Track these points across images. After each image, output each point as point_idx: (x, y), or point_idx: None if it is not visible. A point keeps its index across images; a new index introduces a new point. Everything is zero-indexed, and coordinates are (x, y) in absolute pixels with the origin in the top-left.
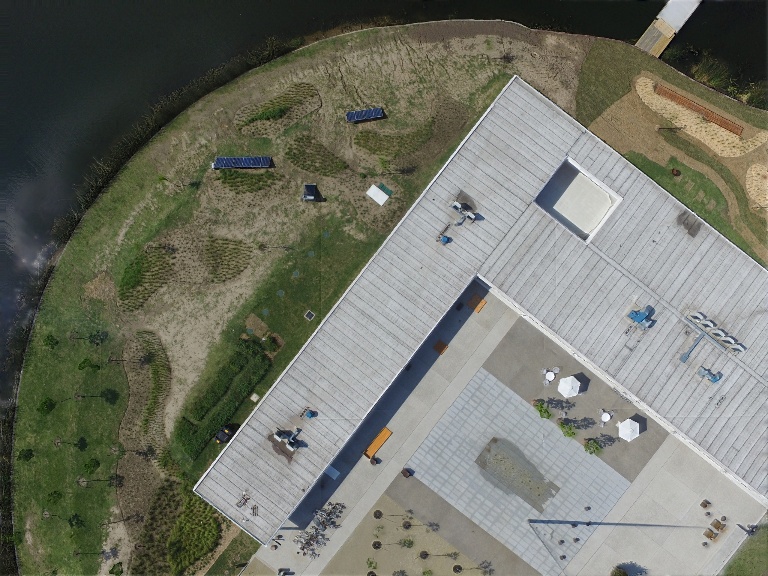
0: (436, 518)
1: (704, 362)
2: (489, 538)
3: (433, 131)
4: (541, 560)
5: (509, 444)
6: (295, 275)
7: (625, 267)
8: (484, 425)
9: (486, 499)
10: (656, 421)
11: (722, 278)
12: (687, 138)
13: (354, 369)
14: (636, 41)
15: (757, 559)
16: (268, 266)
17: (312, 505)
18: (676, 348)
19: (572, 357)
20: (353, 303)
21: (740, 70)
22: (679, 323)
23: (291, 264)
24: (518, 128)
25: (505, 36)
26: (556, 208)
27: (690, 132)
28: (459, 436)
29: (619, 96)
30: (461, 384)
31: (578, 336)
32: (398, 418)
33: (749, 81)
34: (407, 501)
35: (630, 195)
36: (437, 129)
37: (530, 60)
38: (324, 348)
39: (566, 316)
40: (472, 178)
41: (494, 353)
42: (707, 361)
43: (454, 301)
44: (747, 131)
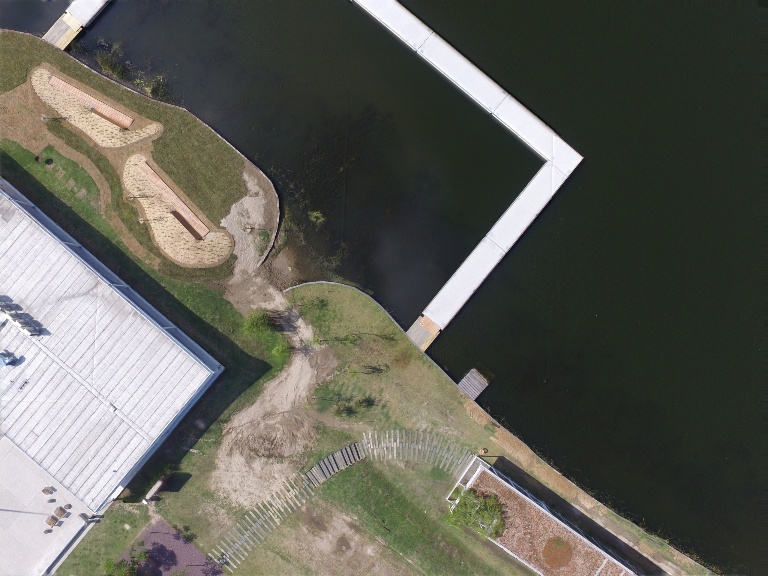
0: None
1: (9, 346)
2: None
3: None
4: None
5: None
6: None
7: None
8: None
9: None
10: None
11: (31, 263)
12: (70, 128)
13: None
14: None
15: (104, 550)
16: None
17: None
18: None
19: None
20: None
21: (149, 63)
22: None
23: None
24: None
25: None
26: None
27: (74, 122)
28: None
29: (12, 86)
30: None
31: None
32: None
33: (156, 74)
34: None
35: None
36: None
37: None
38: None
39: None
40: None
41: None
42: (12, 345)
43: None
44: (138, 123)
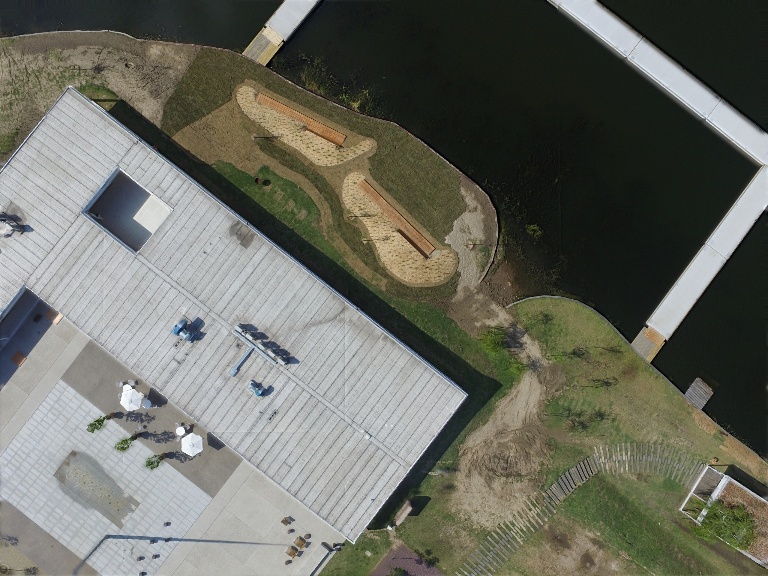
0: (15, 532)
1: (255, 376)
2: (68, 553)
3: (15, 142)
4: None
5: (88, 458)
6: None
7: (174, 279)
8: (63, 438)
9: (65, 513)
10: None
11: (274, 290)
12: (283, 147)
13: None
14: (244, 50)
15: None
16: None
17: None
18: (227, 361)
19: None
20: None
21: (353, 77)
22: (230, 336)
23: None
24: (69, 139)
25: (108, 47)
26: (136, 219)
27: (286, 141)
28: (38, 449)
29: (218, 105)
30: (40, 396)
31: (125, 349)
32: None
33: (362, 88)
34: None
35: (181, 206)
36: (19, 140)
37: (121, 70)
38: None
39: (114, 328)
40: (22, 189)
41: (73, 365)
42: (259, 375)
43: None
44: (351, 139)
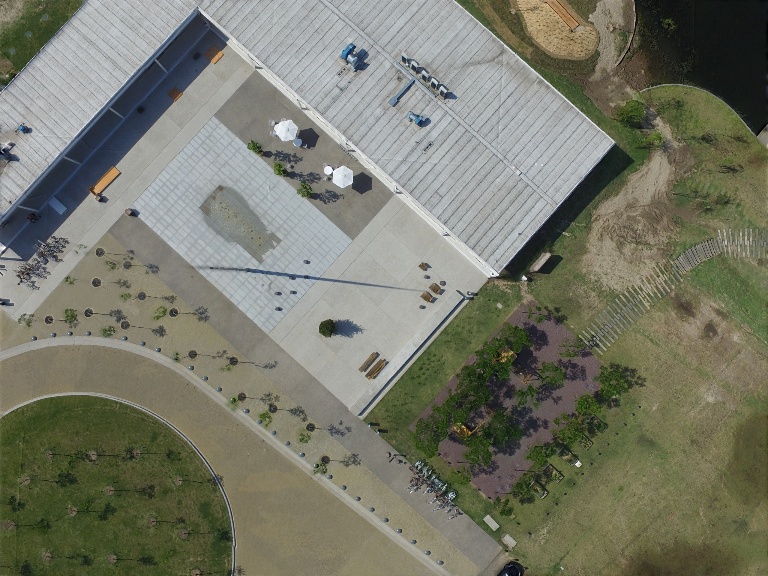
0: (157, 260)
1: (414, 108)
2: (207, 284)
3: None
4: (257, 310)
5: (234, 193)
6: (44, 18)
7: (342, 11)
8: (211, 172)
9: (207, 245)
10: (381, 181)
11: (437, 29)
12: None
13: (71, 90)
14: None
15: (476, 329)
16: (20, 8)
17: (37, 238)
18: (387, 92)
19: (303, 113)
20: (77, 28)
21: None
22: (392, 68)
23: (41, 8)
24: None
25: None
26: None
27: None
28: (186, 181)
29: None
30: (192, 131)
31: (290, 73)
32: (128, 159)
33: None
34: (130, 241)
35: None
36: None
37: None
38: (45, 68)
39: (281, 53)
40: None
41: (227, 104)
42: (417, 107)
43: (173, 31)
44: None
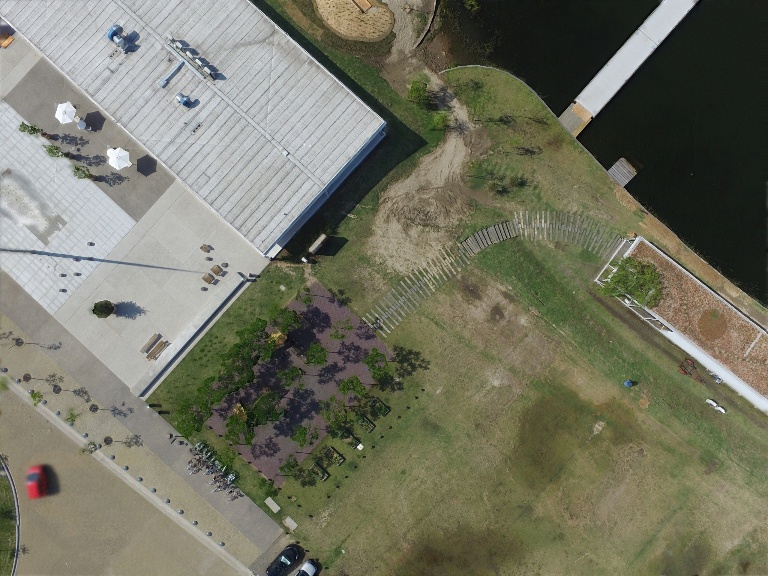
0: None
1: (183, 89)
2: None
3: None
4: (43, 292)
5: (22, 176)
6: None
7: None
8: (0, 156)
9: None
10: None
11: (209, 10)
12: None
13: None
14: None
15: (259, 311)
16: None
17: None
18: (158, 74)
19: None
20: None
21: None
22: (163, 50)
23: None
24: None
25: None
26: None
27: None
28: None
29: None
30: None
31: (62, 55)
32: None
33: None
34: None
35: None
36: None
37: None
38: None
39: (54, 36)
40: None
41: (16, 87)
42: (187, 88)
43: None
44: None
